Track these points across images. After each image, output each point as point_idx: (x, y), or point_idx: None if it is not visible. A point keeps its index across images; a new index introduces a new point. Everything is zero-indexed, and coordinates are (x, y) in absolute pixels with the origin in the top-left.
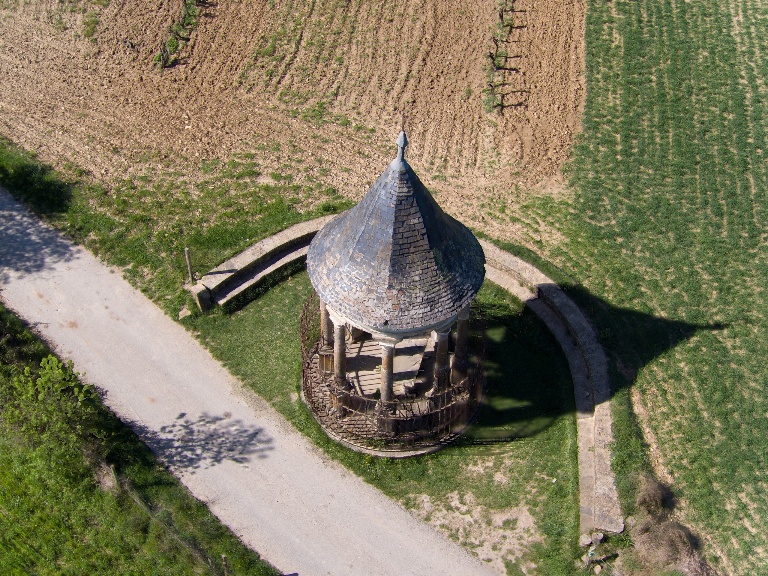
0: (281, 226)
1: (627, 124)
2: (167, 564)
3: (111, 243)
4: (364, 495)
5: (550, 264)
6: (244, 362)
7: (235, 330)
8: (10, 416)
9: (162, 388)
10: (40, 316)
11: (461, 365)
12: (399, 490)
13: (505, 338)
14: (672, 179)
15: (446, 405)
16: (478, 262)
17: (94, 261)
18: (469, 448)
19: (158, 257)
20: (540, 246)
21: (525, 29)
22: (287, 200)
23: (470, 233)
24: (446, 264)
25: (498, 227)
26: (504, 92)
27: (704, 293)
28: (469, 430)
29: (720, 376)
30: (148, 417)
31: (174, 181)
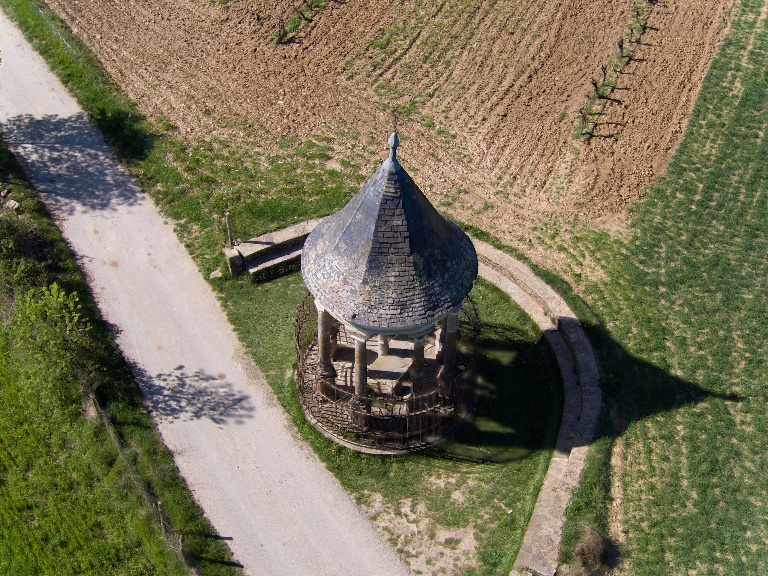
0: (331, 211)
1: (714, 175)
2: (119, 499)
3: (173, 196)
4: (321, 481)
5: (578, 299)
6: (254, 331)
7: (257, 299)
8: (22, 332)
9: (172, 338)
10: (89, 250)
11: (448, 377)
12: (356, 484)
13: (513, 362)
14: (741, 239)
15: (417, 412)
16: (466, 277)
17: (153, 210)
18: (438, 460)
19: (210, 217)
20: (577, 279)
21: (644, 63)
22: (347, 187)
23: (472, 248)
24: (426, 271)
25: (542, 252)
26: (598, 121)
27: (731, 361)
28: (443, 443)
29: (715, 448)
30: (150, 362)
31: (249, 150)
